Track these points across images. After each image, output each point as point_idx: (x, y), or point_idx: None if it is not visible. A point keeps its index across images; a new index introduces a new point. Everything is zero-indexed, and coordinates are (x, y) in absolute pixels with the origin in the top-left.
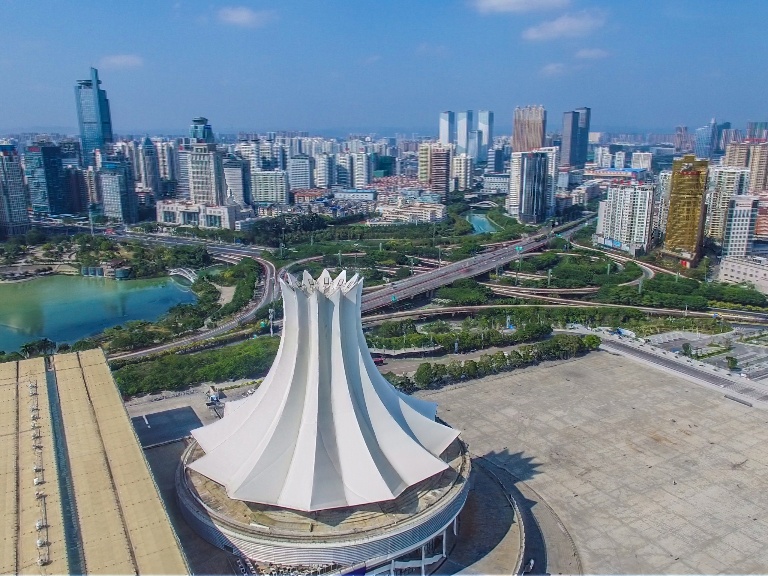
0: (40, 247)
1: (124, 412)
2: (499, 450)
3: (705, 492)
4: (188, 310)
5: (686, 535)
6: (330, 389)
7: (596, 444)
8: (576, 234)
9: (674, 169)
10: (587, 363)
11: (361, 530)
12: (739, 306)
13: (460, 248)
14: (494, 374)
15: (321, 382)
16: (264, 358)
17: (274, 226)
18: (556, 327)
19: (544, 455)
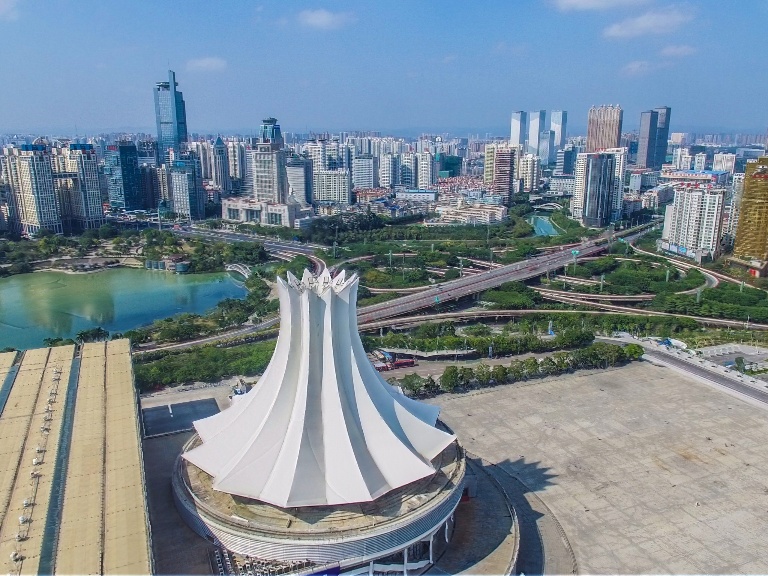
0: (111, 241)
1: (132, 400)
2: (515, 458)
3: (729, 516)
4: (236, 305)
5: (699, 560)
6: (321, 387)
7: (619, 458)
8: None
9: (747, 172)
10: (626, 373)
11: (337, 530)
12: None
13: (515, 251)
14: (525, 380)
15: (311, 380)
16: None
17: (331, 225)
18: (601, 335)
19: (561, 466)
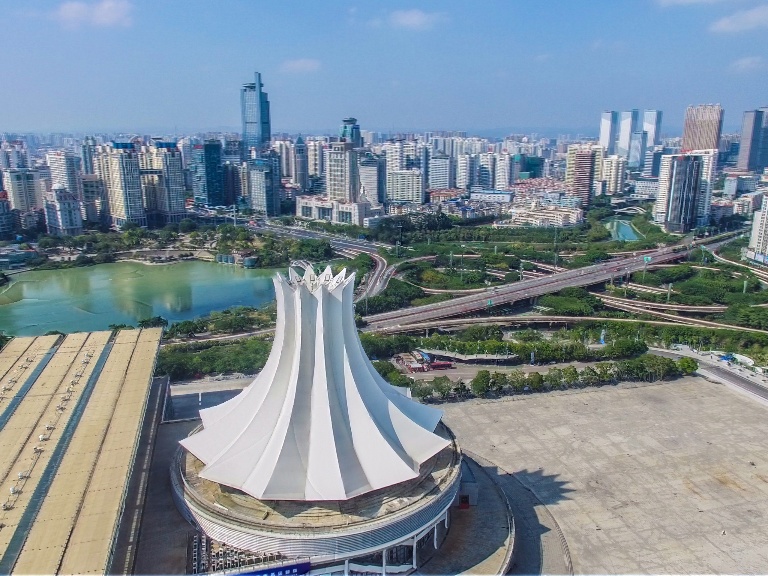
0: (189, 235)
1: (146, 386)
2: (533, 469)
3: (757, 549)
4: None
5: None
6: (311, 384)
7: (646, 477)
8: (725, 246)
9: None
10: (674, 388)
11: (310, 525)
12: None
13: (583, 255)
14: (562, 389)
15: (301, 376)
16: None
17: (399, 224)
18: (659, 346)
19: (581, 481)
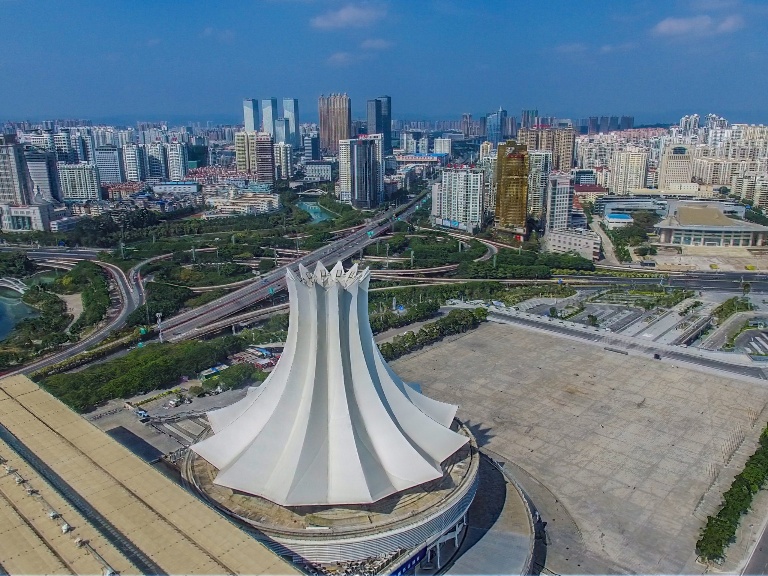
0: None
1: (109, 438)
2: None
3: (628, 430)
4: (39, 324)
5: (631, 468)
6: (351, 381)
7: (526, 404)
8: (412, 217)
9: (499, 153)
10: (483, 334)
11: (418, 512)
12: (574, 272)
13: (311, 236)
14: (408, 353)
15: (345, 375)
16: (173, 365)
17: (100, 225)
18: None
19: (488, 420)
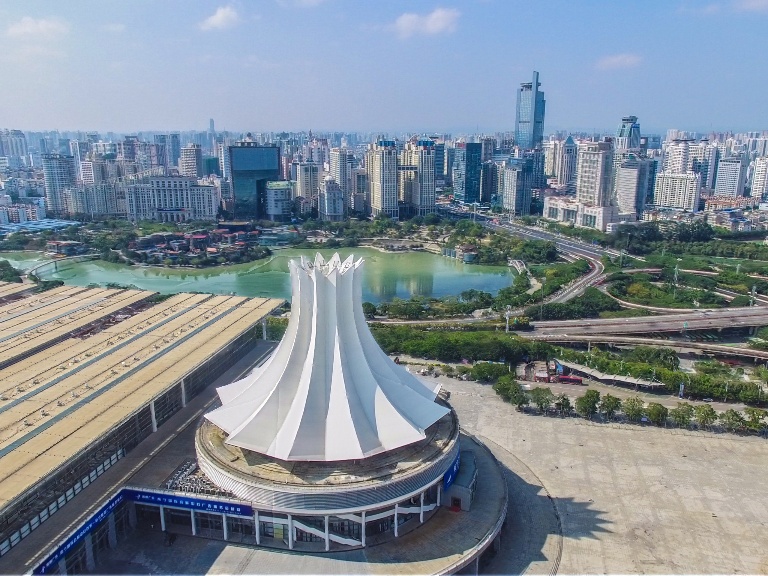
0: None
1: (226, 342)
2: (581, 499)
3: None
4: (477, 296)
5: None
6: (306, 357)
7: (714, 543)
8: None
9: None
10: None
11: (258, 475)
12: None
13: None
14: (690, 429)
15: (296, 348)
16: (460, 346)
17: (643, 232)
18: None
19: (627, 525)
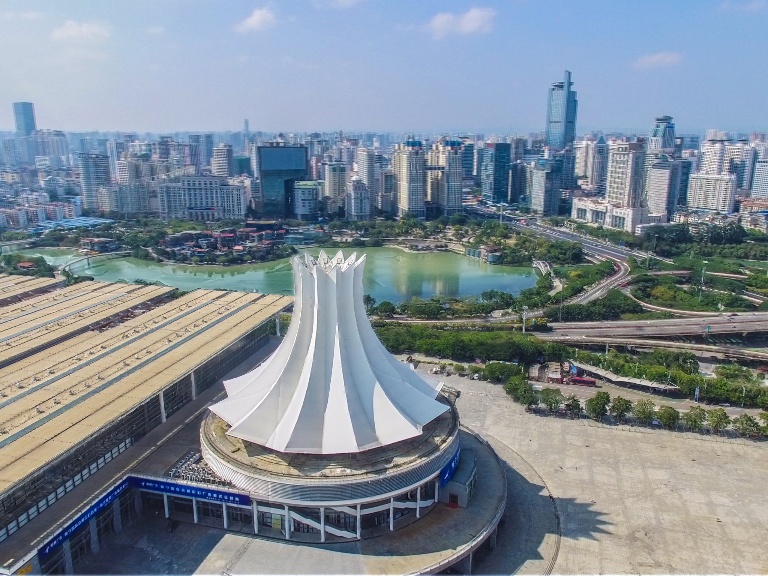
0: None
1: (236, 337)
2: (583, 500)
3: None
4: (497, 297)
5: None
6: (307, 352)
7: (715, 548)
8: None
9: None
10: None
11: (256, 466)
12: None
13: None
14: (702, 433)
15: (297, 343)
16: (473, 346)
17: (673, 234)
18: None
19: (627, 527)
